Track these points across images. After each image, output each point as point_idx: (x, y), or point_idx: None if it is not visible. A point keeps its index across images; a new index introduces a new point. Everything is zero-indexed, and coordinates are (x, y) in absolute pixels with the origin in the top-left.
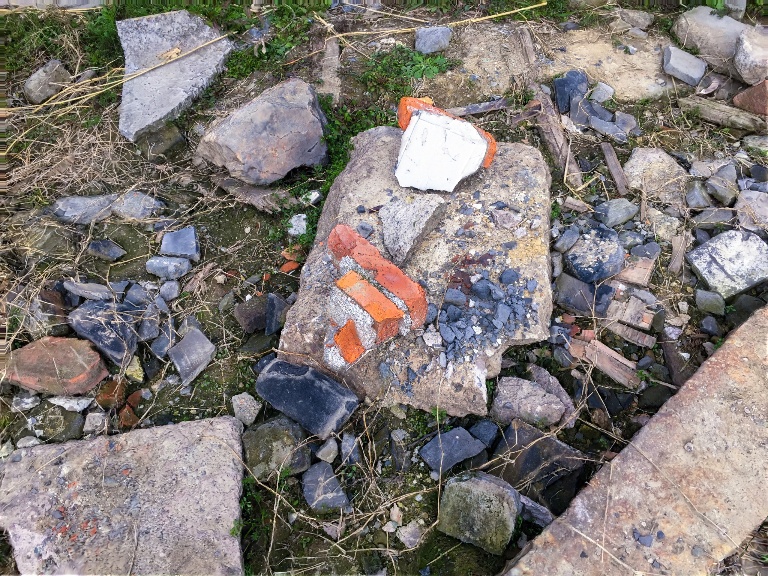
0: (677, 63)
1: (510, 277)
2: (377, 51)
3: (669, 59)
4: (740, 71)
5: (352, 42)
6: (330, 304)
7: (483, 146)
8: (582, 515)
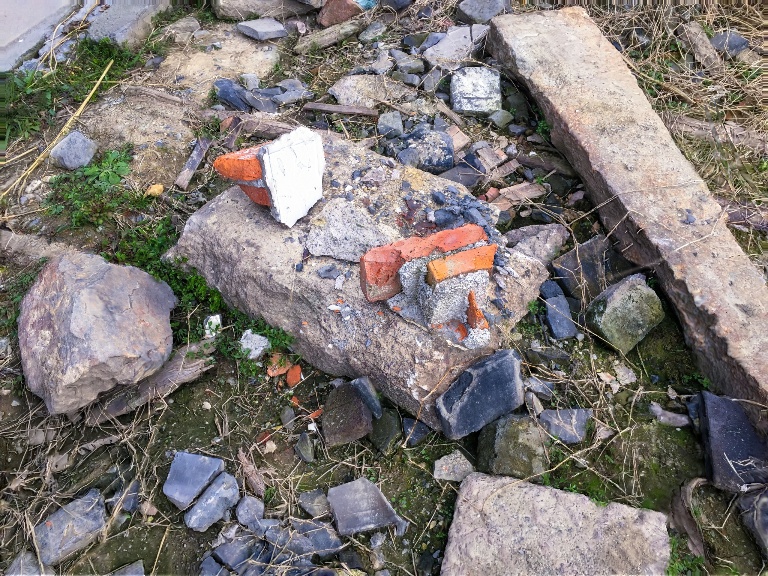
0: (261, 29)
1: (442, 196)
2: (41, 199)
3: (254, 30)
4: (308, 2)
5: (4, 214)
6: (438, 306)
7: (319, 138)
8: (666, 242)
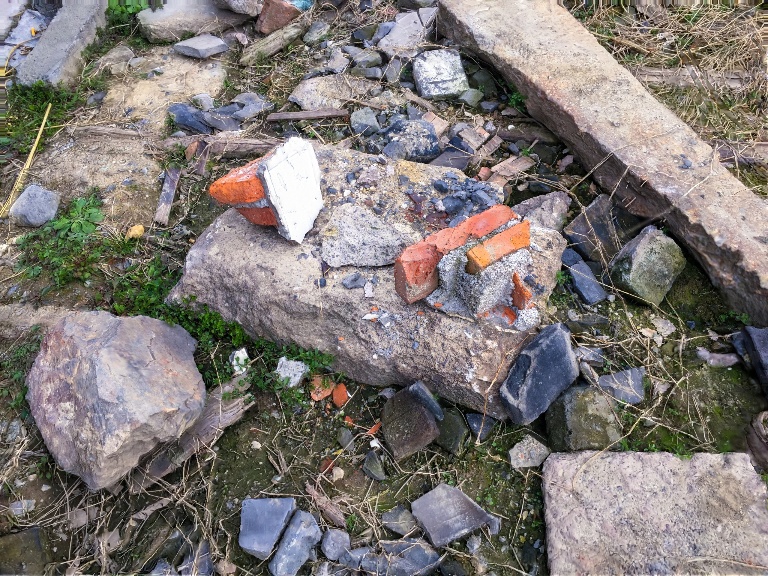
0: (201, 46)
1: (444, 184)
2: (12, 264)
3: (193, 49)
4: (244, 12)
5: None
6: (485, 294)
7: (310, 146)
8: (672, 190)
